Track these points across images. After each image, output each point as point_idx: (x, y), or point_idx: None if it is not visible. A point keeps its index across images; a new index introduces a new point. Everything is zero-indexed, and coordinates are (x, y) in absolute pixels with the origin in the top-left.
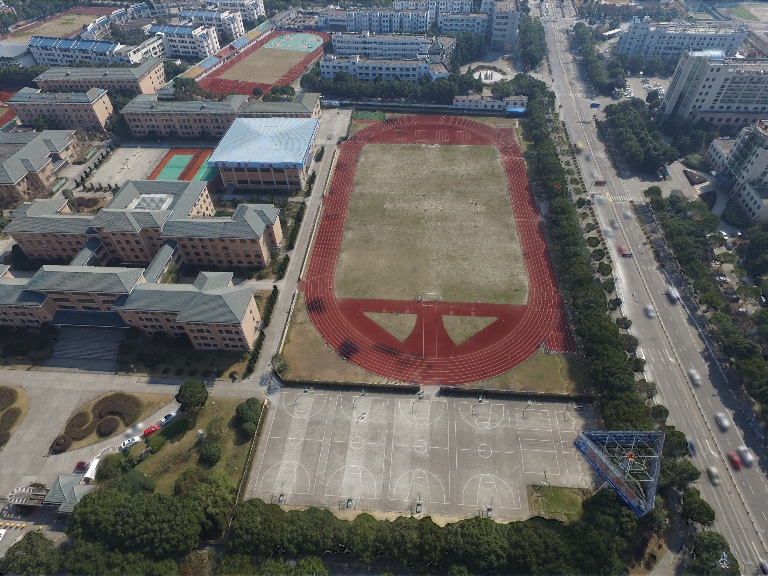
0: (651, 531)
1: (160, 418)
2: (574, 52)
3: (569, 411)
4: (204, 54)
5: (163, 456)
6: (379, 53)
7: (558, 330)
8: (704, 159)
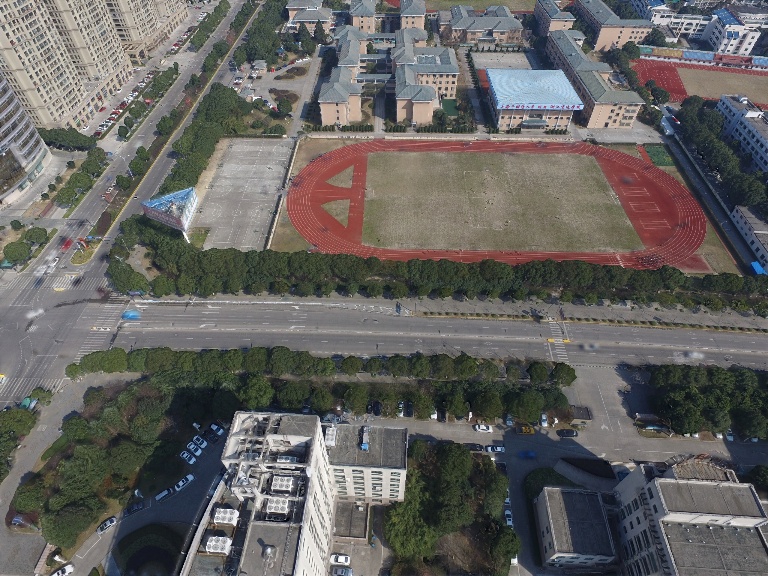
0: None
1: None
2: None
3: None
4: (717, 50)
5: (261, 115)
6: None
7: None
8: None
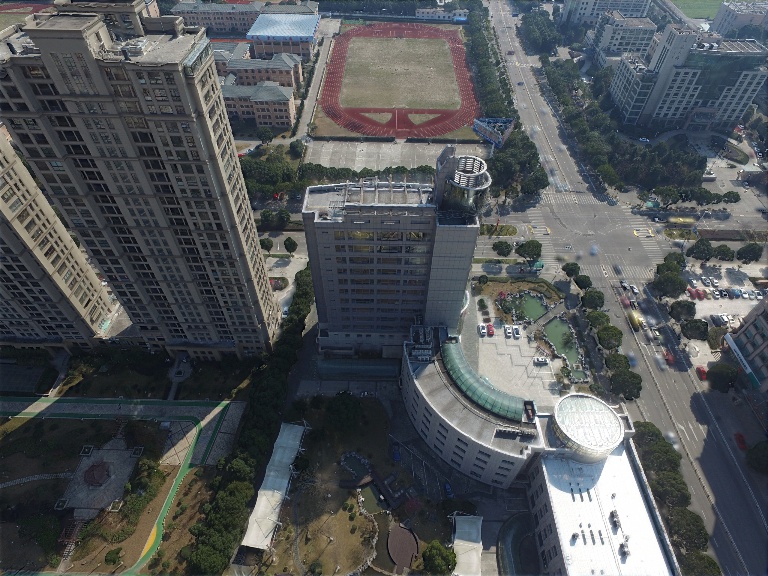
0: (513, 181)
1: (244, 152)
2: None
3: (478, 147)
4: None
5: None
6: None
7: None
8: (583, 45)
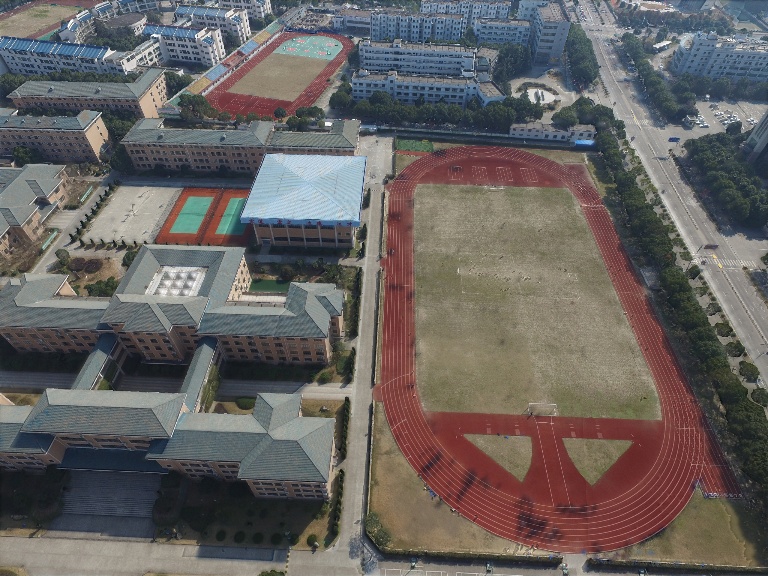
0: None
1: None
2: (628, 68)
3: None
4: (208, 61)
5: None
6: (412, 65)
7: (711, 460)
8: None
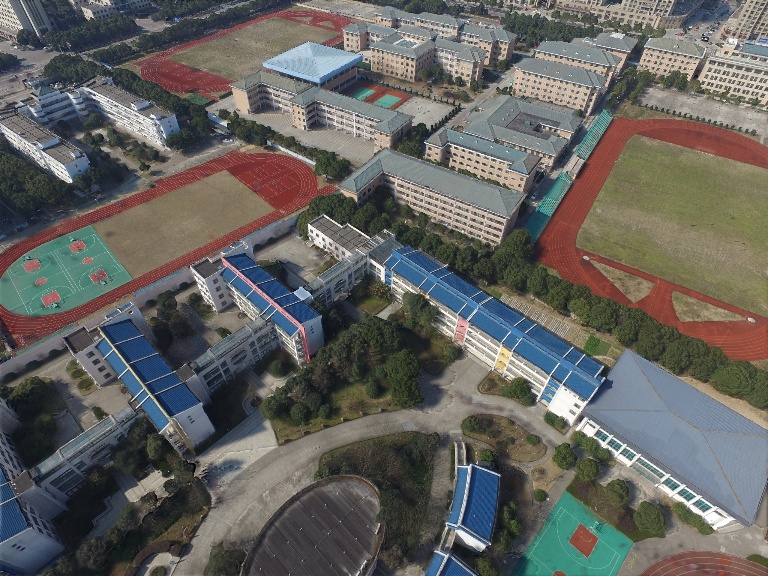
0: None
1: None
2: None
3: None
4: None
5: None
6: None
7: None
8: None
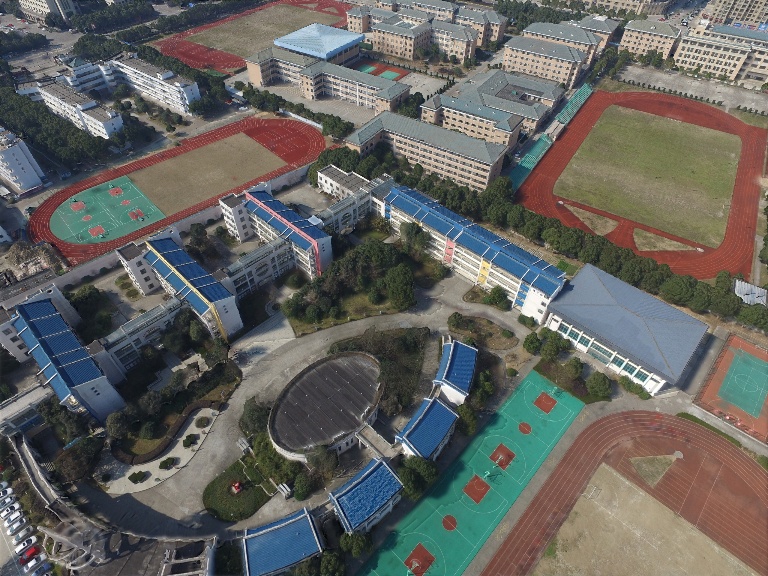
0: None
1: None
2: None
3: None
4: None
5: None
6: None
7: None
8: None
